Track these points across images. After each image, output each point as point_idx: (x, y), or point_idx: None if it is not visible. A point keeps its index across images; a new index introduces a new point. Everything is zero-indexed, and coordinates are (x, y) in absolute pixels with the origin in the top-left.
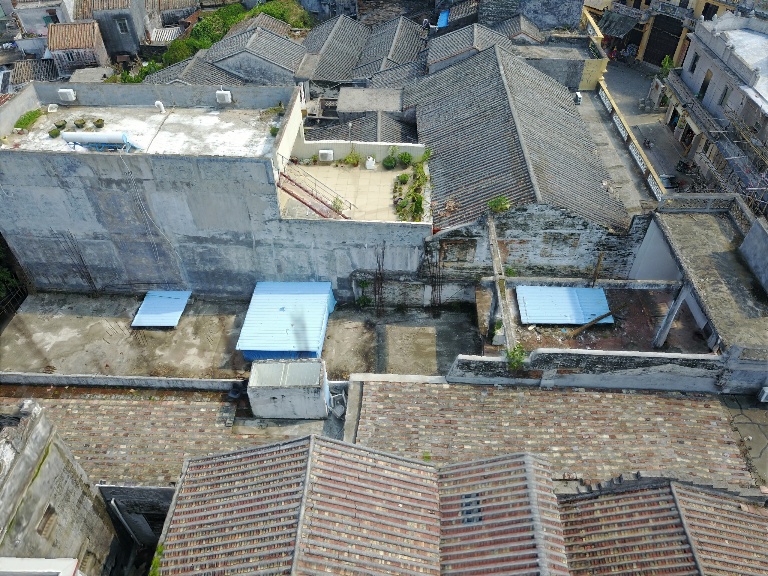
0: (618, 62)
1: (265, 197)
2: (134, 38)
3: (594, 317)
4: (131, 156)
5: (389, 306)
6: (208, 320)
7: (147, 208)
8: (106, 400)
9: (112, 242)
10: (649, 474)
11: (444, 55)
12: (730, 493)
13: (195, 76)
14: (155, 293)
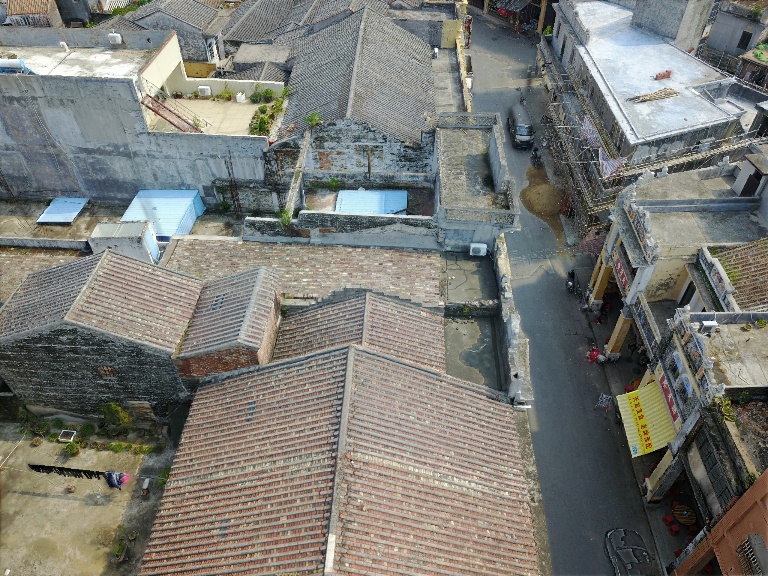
0: (520, 35)
1: (133, 113)
2: (86, 6)
3: (392, 212)
4: (25, 77)
5: (247, 212)
6: (99, 219)
7: (44, 122)
8: None
9: (21, 153)
10: (352, 286)
11: (327, 16)
12: (415, 304)
13: None
14: (60, 199)
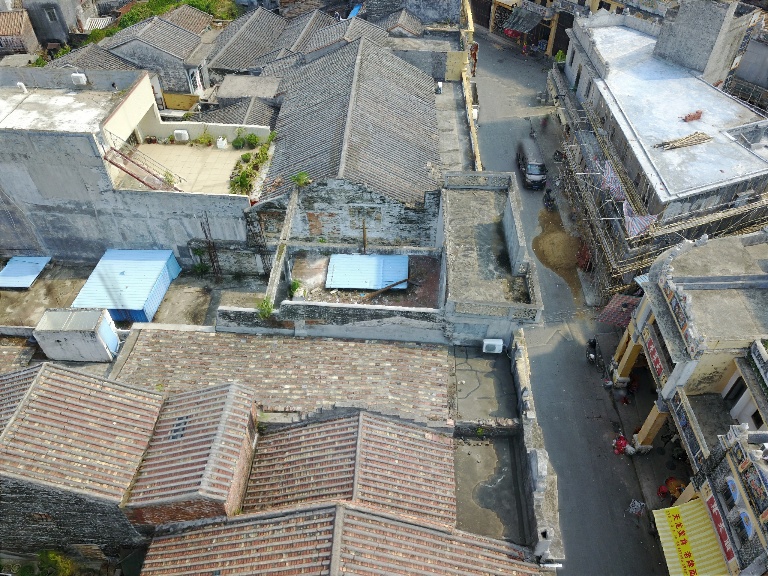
0: (528, 57)
1: (95, 169)
2: (63, 26)
3: (391, 283)
4: None
5: (228, 274)
6: (61, 283)
7: None
8: None
9: None
10: (342, 404)
11: (319, 45)
12: (418, 424)
13: (87, 62)
14: (18, 258)
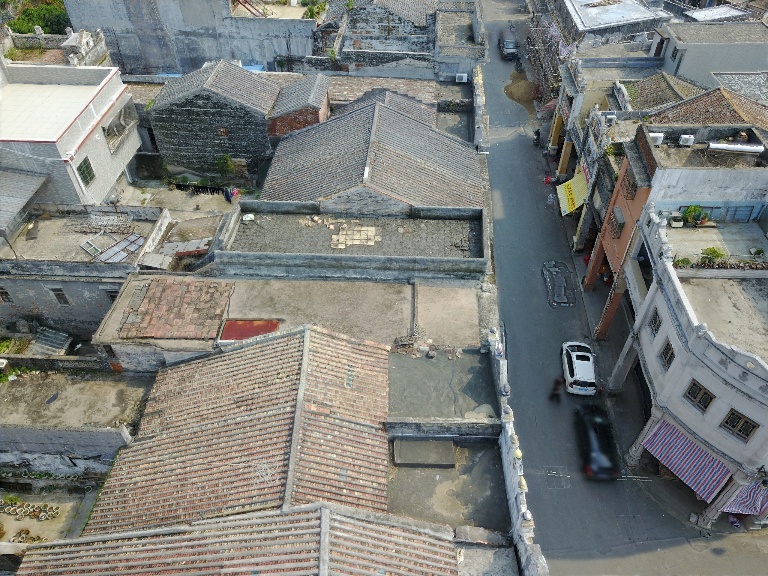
0: None
1: (222, 1)
2: None
3: None
4: None
5: None
6: None
7: (157, 10)
8: (131, 86)
9: (137, 36)
10: (377, 87)
11: None
12: (418, 101)
13: None
14: (161, 74)
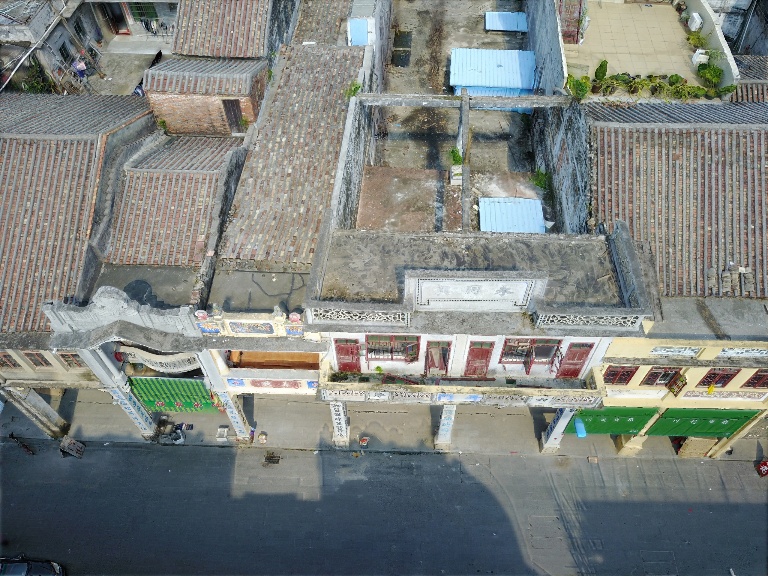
0: None
1: None
2: None
3: None
4: None
5: None
6: (500, 47)
7: None
8: None
9: None
10: (228, 155)
11: None
12: None
13: None
14: (523, 15)
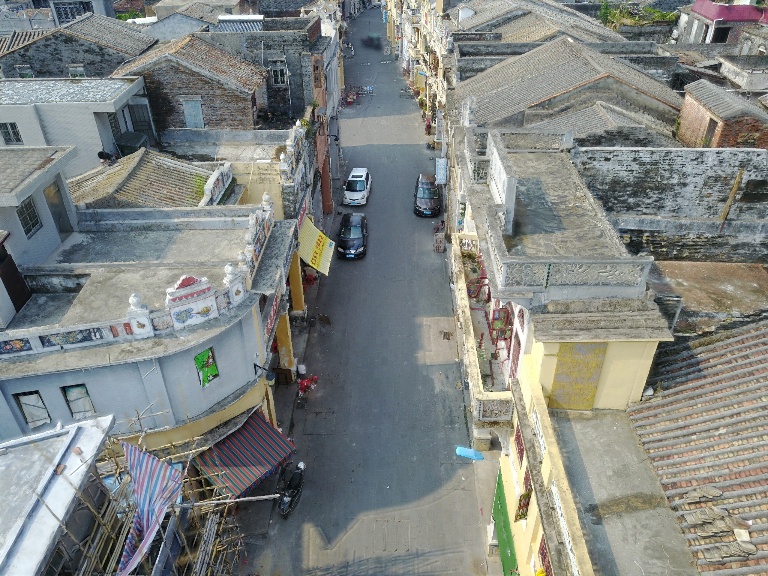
0: None
1: None
2: None
3: None
4: None
5: None
6: None
7: None
8: None
9: None
10: (638, 125)
11: None
12: None
13: None
14: None
